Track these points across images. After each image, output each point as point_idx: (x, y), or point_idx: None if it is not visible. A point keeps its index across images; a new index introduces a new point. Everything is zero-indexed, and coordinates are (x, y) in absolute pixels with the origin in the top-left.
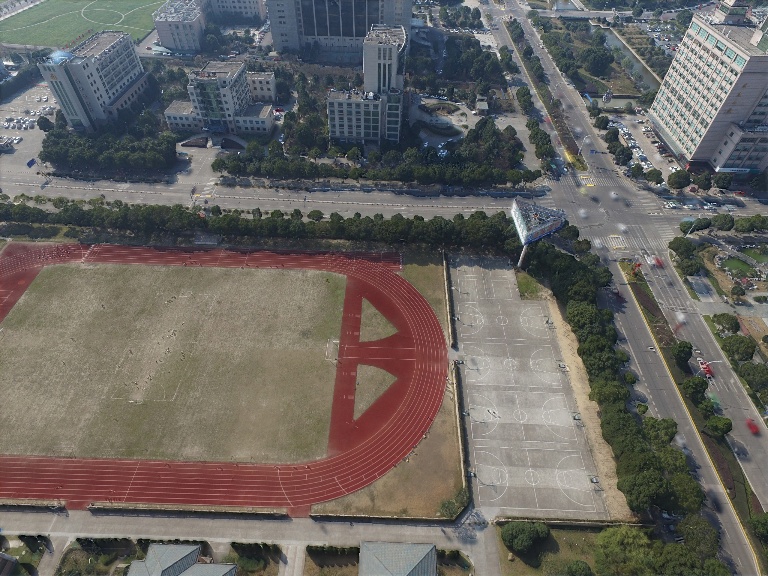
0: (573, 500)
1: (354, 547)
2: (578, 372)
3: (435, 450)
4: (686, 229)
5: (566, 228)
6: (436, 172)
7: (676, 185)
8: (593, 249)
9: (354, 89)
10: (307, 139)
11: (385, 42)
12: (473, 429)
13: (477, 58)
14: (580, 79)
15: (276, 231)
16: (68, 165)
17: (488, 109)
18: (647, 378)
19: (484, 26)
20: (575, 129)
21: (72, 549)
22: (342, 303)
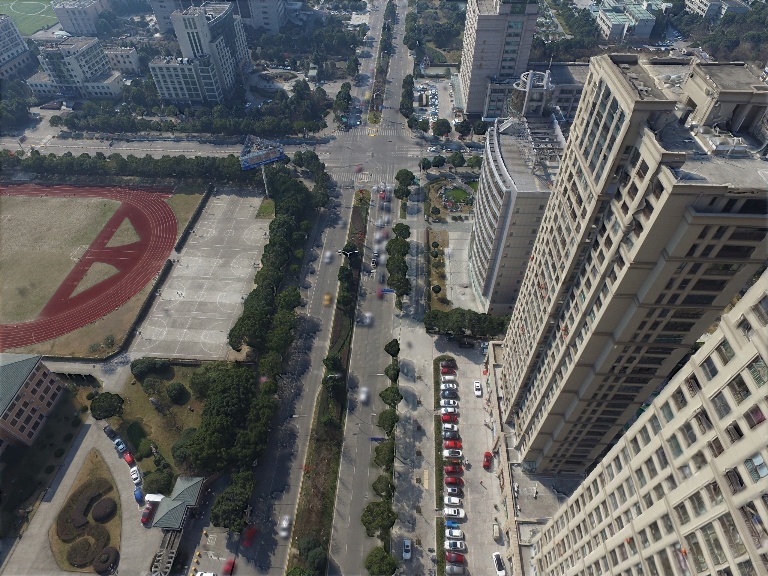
0: (205, 349)
1: None
2: None
3: (119, 317)
4: (420, 165)
5: (312, 164)
6: (231, 123)
7: (436, 132)
8: (341, 182)
9: None
10: (140, 100)
11: (190, 13)
12: (158, 304)
13: (327, 33)
14: (423, 51)
15: (73, 168)
16: None
17: (322, 76)
18: (321, 272)
19: (366, 8)
20: (390, 91)
21: None
22: (107, 221)
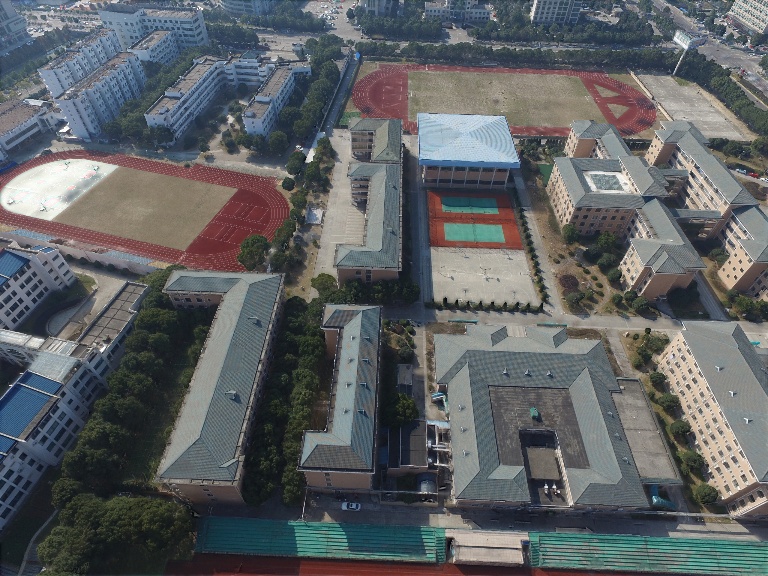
0: (734, 139)
1: (644, 142)
2: (722, 107)
3: None
4: None
5: (699, 55)
6: (610, 35)
7: (756, 42)
8: None
9: (525, 3)
10: (520, 22)
11: None
12: None
13: None
14: (674, 1)
15: (534, 56)
16: (377, 34)
17: None
18: None
19: None
20: (681, 24)
21: (516, 145)
22: (583, 85)
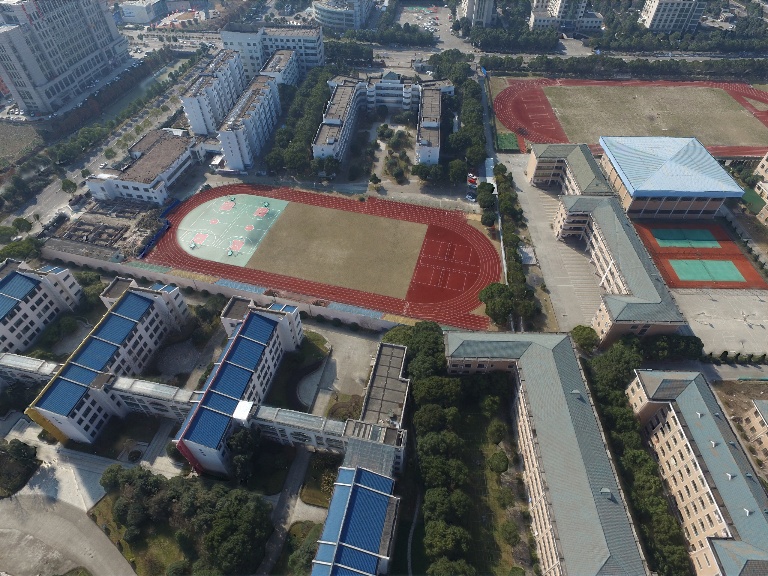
0: None
1: None
2: None
3: None
4: None
5: None
6: (739, 42)
7: None
8: None
9: None
10: (636, 30)
11: None
12: None
13: None
14: None
15: (671, 67)
16: (490, 47)
17: None
18: None
19: None
20: None
21: None
22: (733, 98)
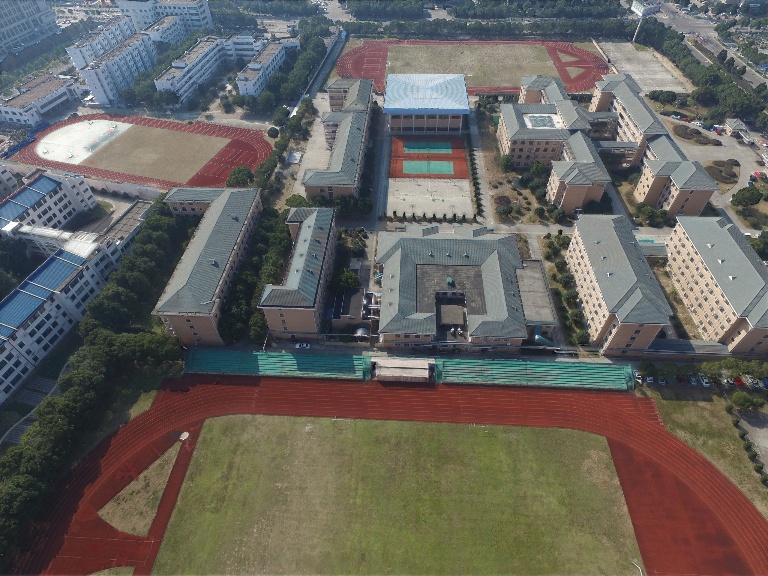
0: None
1: (591, 96)
2: (672, 67)
3: None
4: None
5: (658, 23)
6: (578, 9)
7: (717, 11)
8: None
9: None
10: (496, 1)
11: None
12: None
13: None
14: None
15: (504, 28)
16: (365, 16)
17: None
18: None
19: None
20: None
21: (477, 101)
22: (547, 53)
